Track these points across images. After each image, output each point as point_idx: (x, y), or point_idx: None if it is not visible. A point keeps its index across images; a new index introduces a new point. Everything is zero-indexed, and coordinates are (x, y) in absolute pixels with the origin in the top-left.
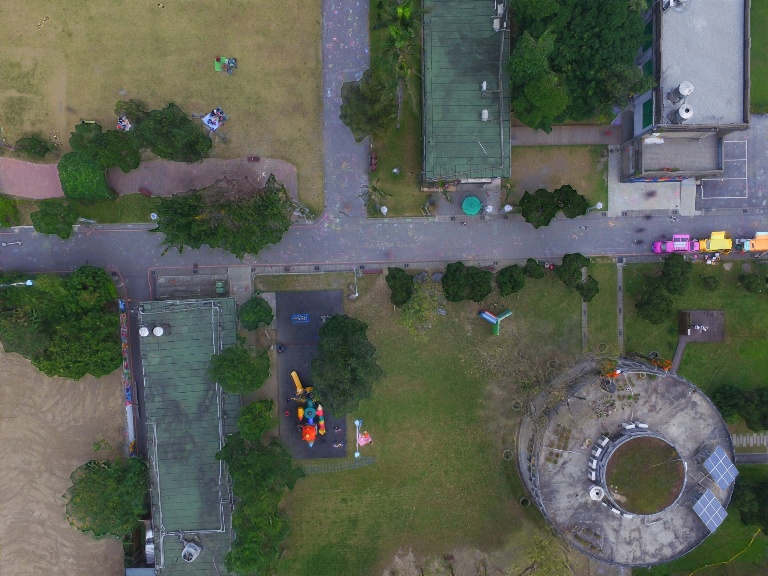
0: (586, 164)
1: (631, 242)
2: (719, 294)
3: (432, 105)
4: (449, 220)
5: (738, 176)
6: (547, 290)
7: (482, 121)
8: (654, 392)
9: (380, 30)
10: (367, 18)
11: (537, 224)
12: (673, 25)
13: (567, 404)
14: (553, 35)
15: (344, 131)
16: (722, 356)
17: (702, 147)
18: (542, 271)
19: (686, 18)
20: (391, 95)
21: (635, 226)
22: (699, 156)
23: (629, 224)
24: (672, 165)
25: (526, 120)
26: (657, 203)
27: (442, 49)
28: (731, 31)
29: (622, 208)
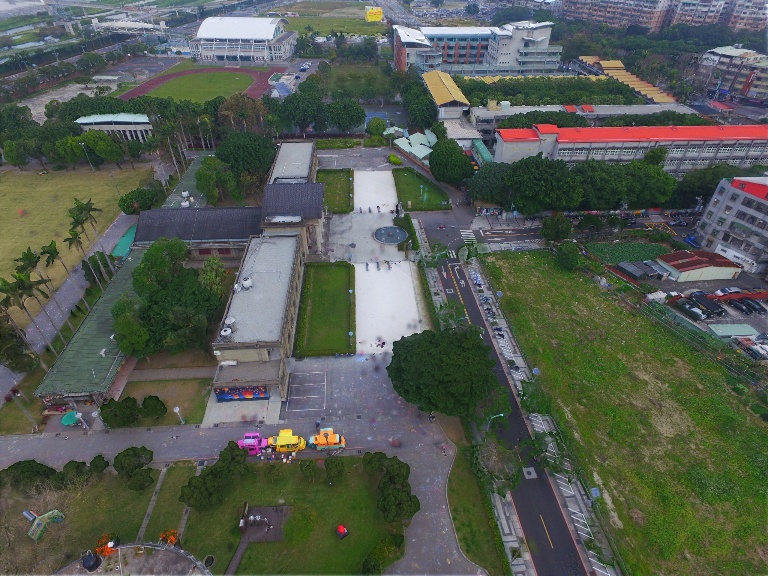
0: (193, 391)
1: (215, 447)
2: (292, 490)
3: (70, 350)
4: (53, 436)
5: (318, 394)
6: (117, 493)
7: (102, 357)
8: (149, 572)
9: (73, 322)
10: (68, 316)
11: (107, 420)
12: (241, 298)
13: (10, 569)
14: (142, 297)
15: (4, 377)
16: (287, 557)
17: (269, 367)
18: (102, 464)
19: (251, 295)
20: (6, 325)
21: (223, 434)
22: (266, 372)
23: (218, 433)
24: (243, 379)
25: (120, 347)
26: (246, 416)
27: (96, 321)
28: (279, 299)
29: (215, 421)
